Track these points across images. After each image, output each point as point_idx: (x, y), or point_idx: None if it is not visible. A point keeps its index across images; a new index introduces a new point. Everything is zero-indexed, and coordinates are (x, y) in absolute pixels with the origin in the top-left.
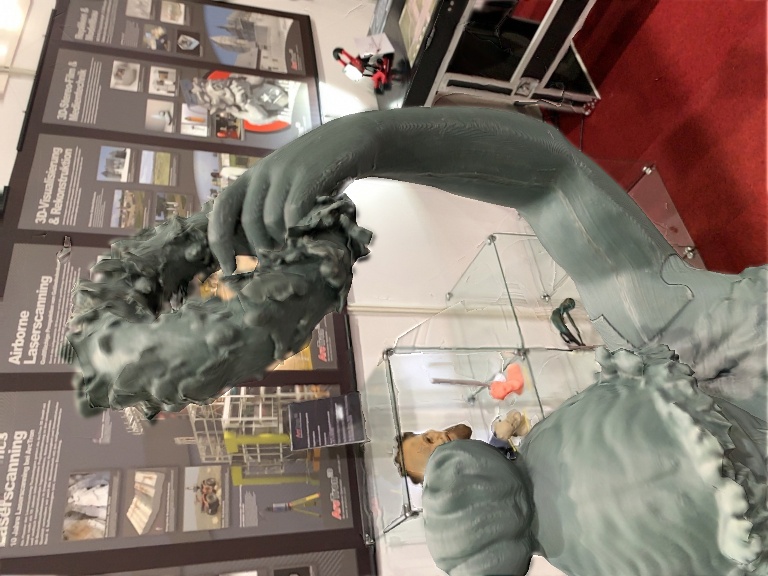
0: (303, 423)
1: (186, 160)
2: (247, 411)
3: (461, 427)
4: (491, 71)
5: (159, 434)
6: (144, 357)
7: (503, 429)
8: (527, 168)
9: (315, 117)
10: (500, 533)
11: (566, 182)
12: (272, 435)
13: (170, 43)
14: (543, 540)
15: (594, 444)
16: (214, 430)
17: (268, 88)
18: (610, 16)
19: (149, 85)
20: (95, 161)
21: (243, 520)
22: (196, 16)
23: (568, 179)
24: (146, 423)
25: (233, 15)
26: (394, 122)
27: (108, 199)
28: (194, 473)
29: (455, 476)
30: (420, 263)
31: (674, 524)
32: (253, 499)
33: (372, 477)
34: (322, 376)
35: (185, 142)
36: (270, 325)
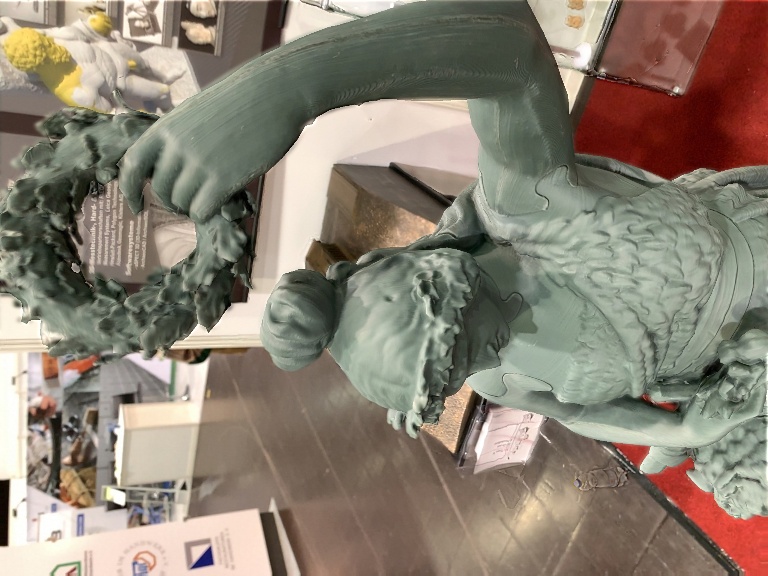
0: None
1: None
2: None
3: None
4: None
5: None
6: (67, 344)
7: None
8: None
9: None
10: None
11: (507, 99)
12: None
13: None
14: None
15: (376, 347)
16: None
17: None
18: None
19: None
20: None
21: None
22: None
23: (510, 98)
24: None
25: None
26: (332, 95)
27: None
28: None
29: (288, 318)
30: None
31: (391, 401)
32: None
33: None
34: None
35: None
36: None
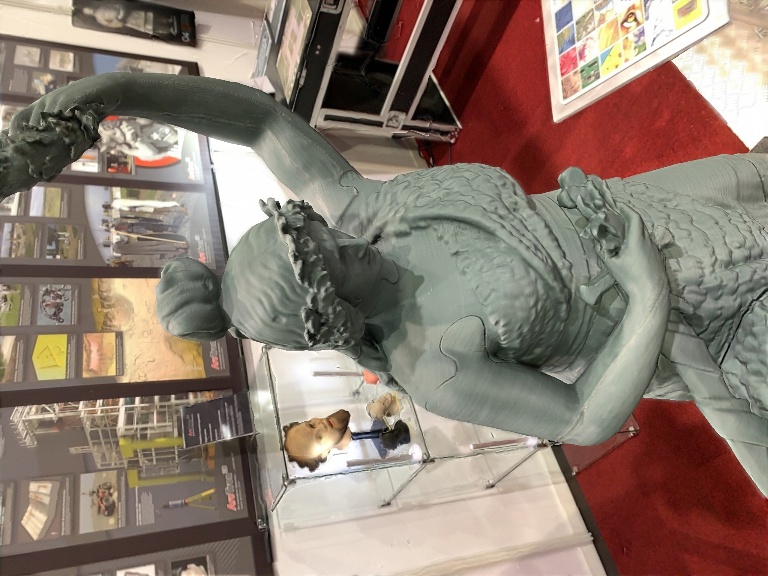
0: (195, 423)
1: (77, 194)
2: (142, 419)
3: (340, 412)
4: (364, 107)
5: (53, 445)
6: None
7: (376, 408)
8: (240, 114)
9: (204, 152)
10: (192, 297)
11: (272, 125)
12: (167, 439)
13: None
14: (226, 308)
15: (244, 243)
16: (109, 438)
17: (158, 127)
18: (463, 58)
19: None
20: None
21: (140, 519)
22: (85, 64)
23: (273, 123)
24: (40, 436)
25: (122, 63)
26: (134, 78)
27: None
28: (90, 479)
29: None
30: None
31: (274, 270)
32: (149, 499)
33: (265, 471)
34: (215, 383)
35: (76, 178)
36: (27, 156)
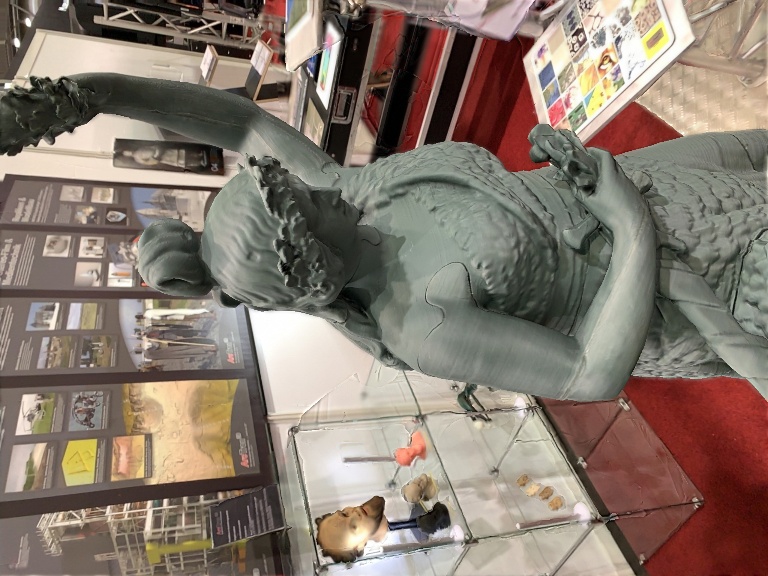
0: (224, 521)
1: (112, 307)
2: (170, 521)
3: (374, 498)
4: None
5: (79, 553)
6: None
7: (411, 490)
8: (225, 114)
9: None
10: (170, 244)
11: (256, 125)
12: (195, 542)
13: (99, 218)
14: (205, 258)
15: None
16: (136, 543)
17: None
18: None
19: (79, 251)
20: (25, 315)
21: None
22: (124, 196)
23: (257, 123)
24: (65, 544)
25: (157, 193)
26: (124, 76)
27: (36, 346)
28: None
29: None
30: (335, 371)
31: (245, 206)
32: None
33: (300, 573)
34: (245, 481)
35: (111, 293)
36: (15, 108)
